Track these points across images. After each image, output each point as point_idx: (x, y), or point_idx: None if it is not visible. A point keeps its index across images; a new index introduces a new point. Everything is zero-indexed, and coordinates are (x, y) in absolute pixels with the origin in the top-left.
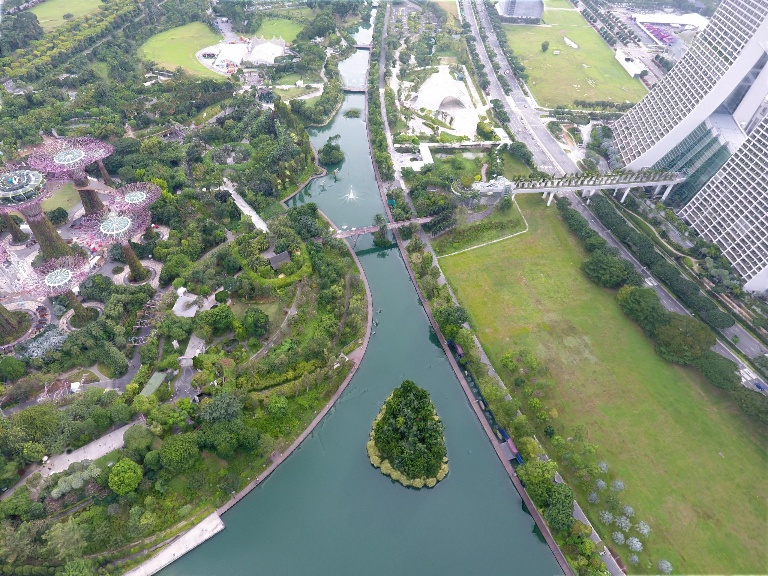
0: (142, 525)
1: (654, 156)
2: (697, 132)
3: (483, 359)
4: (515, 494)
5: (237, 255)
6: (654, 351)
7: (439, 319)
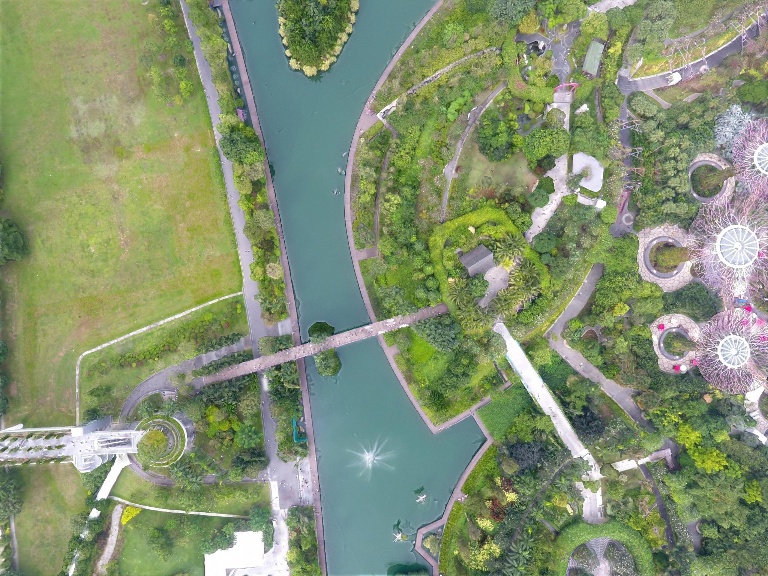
0: None
1: None
2: None
3: (214, 106)
4: None
5: (540, 267)
6: None
7: None
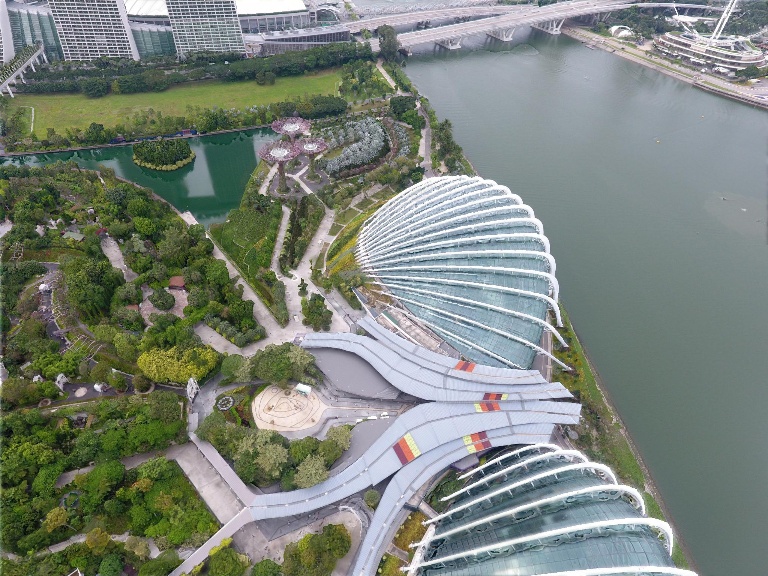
0: (178, 220)
1: (9, 46)
2: (13, 18)
3: None
4: (207, 147)
5: None
6: (156, 92)
7: (94, 135)
